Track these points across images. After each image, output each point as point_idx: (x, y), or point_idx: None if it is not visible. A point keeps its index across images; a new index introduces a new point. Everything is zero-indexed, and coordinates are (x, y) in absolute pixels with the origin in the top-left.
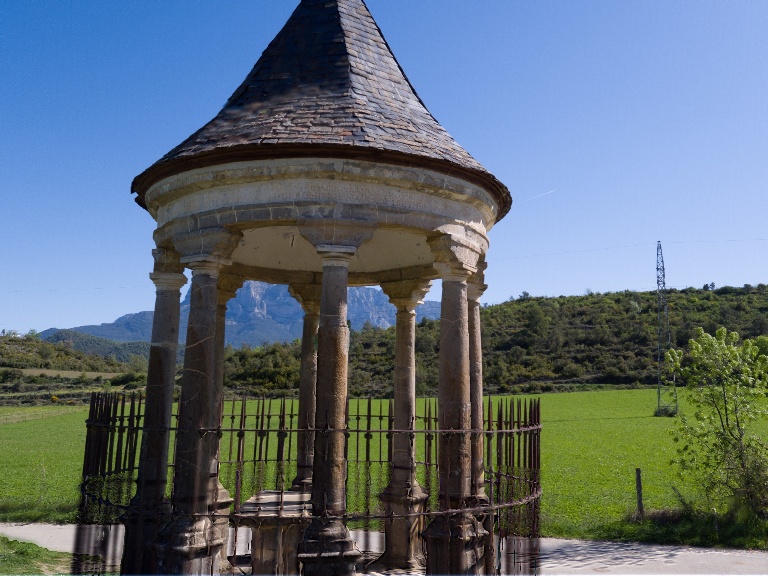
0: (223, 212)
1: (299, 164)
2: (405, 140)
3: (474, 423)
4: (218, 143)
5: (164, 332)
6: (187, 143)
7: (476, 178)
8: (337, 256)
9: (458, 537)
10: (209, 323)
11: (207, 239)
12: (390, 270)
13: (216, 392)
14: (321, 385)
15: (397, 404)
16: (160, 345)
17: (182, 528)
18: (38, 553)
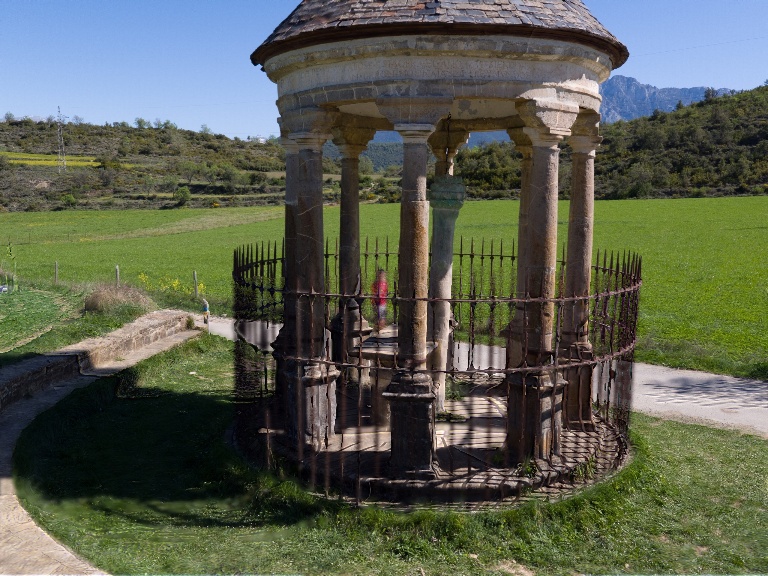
0: (316, 92)
1: (375, 43)
2: (483, 5)
3: (579, 276)
4: (305, 26)
5: (294, 192)
6: (284, 23)
7: (568, 34)
8: (413, 134)
9: (532, 386)
10: (314, 194)
11: (306, 118)
12: (516, 116)
13: (352, 238)
14: (402, 254)
15: (519, 250)
16: (292, 204)
17: (302, 362)
18: (248, 351)
